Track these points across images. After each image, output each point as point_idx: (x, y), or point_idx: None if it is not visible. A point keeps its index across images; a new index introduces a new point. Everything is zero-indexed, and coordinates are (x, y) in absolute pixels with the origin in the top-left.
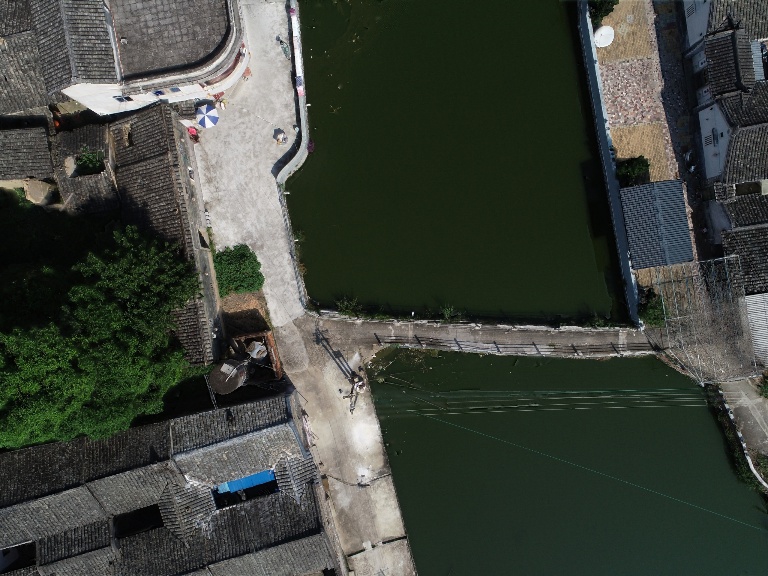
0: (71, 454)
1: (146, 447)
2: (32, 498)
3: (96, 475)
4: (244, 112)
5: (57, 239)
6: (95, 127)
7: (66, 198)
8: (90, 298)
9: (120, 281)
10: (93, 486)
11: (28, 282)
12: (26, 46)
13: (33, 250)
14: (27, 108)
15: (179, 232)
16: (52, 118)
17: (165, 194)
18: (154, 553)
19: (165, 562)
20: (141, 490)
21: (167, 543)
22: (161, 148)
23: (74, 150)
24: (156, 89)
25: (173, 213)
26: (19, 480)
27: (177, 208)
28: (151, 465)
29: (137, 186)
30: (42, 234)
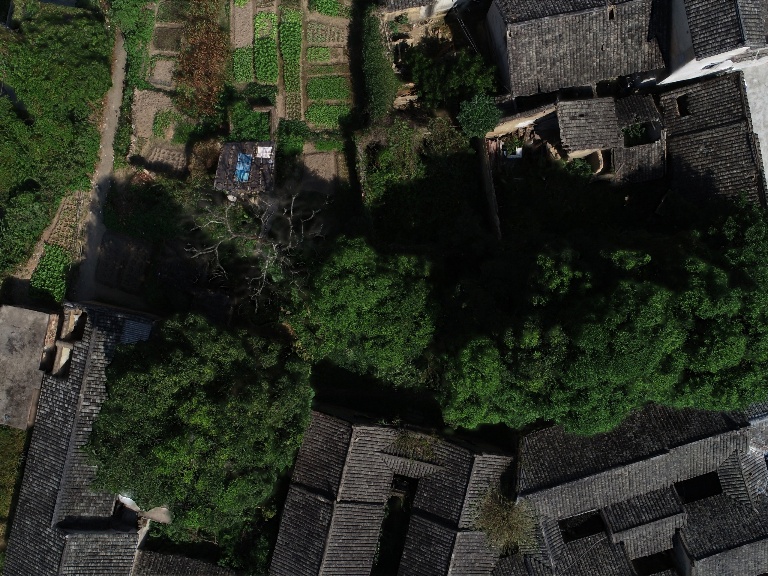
0: (642, 422)
1: (717, 414)
2: (619, 465)
3: (674, 442)
4: (755, 82)
5: (582, 211)
6: (639, 97)
7: (617, 168)
8: (750, 261)
9: (761, 245)
10: (672, 453)
11: (696, 245)
12: (634, 14)
13: (563, 222)
14: (611, 77)
15: (756, 199)
16: (595, 89)
17: (740, 161)
18: (722, 519)
19: (737, 528)
20: (709, 457)
21: (732, 509)
22: (732, 116)
23: (627, 120)
24: (767, 55)
25: (749, 180)
26: (595, 448)
27: (755, 175)
28: (734, 431)
29: (698, 154)
30: (576, 205)
